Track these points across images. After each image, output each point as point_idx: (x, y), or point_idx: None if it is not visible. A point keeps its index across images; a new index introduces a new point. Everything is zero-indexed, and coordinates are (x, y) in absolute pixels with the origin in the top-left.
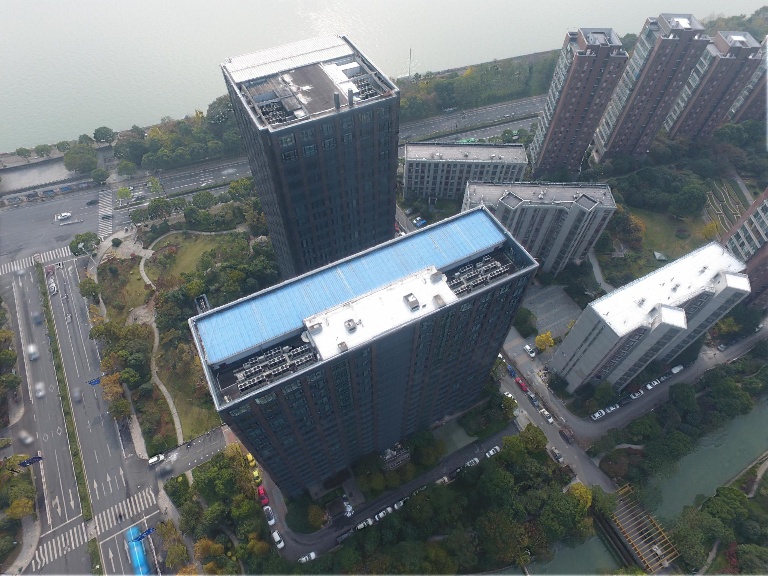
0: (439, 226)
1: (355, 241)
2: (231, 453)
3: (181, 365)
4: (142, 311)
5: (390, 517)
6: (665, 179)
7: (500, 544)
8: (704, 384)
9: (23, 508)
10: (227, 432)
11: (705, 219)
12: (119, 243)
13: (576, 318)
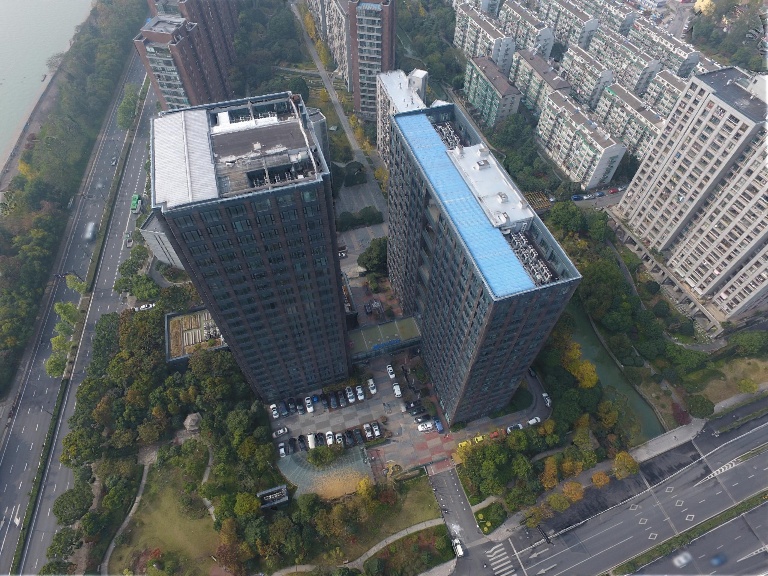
0: None
1: None
2: None
3: (364, 508)
4: None
5: None
6: None
7: None
8: None
9: None
10: (435, 470)
11: None
12: None
13: (373, 188)
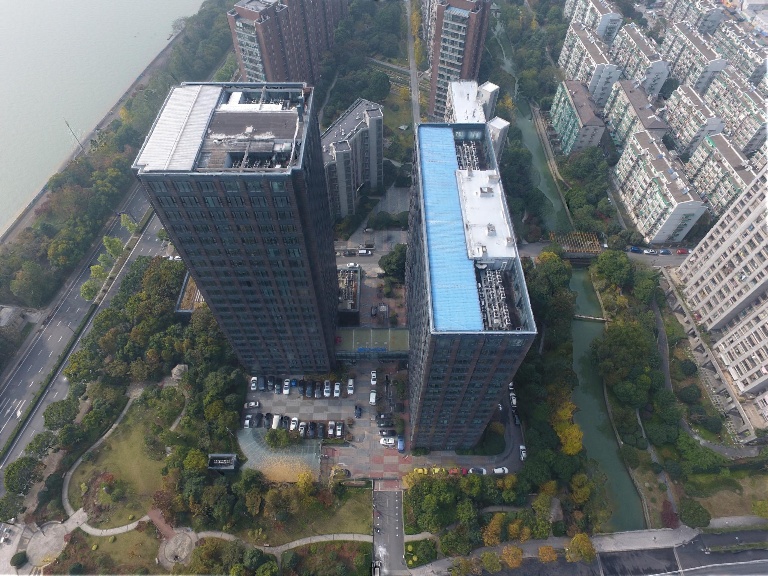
0: (420, 152)
1: (327, 246)
2: (418, 478)
3: (295, 501)
4: (169, 546)
5: (524, 370)
6: (351, 84)
7: (570, 308)
8: (504, 164)
9: None
10: (382, 487)
11: (391, 92)
12: (24, 556)
13: None
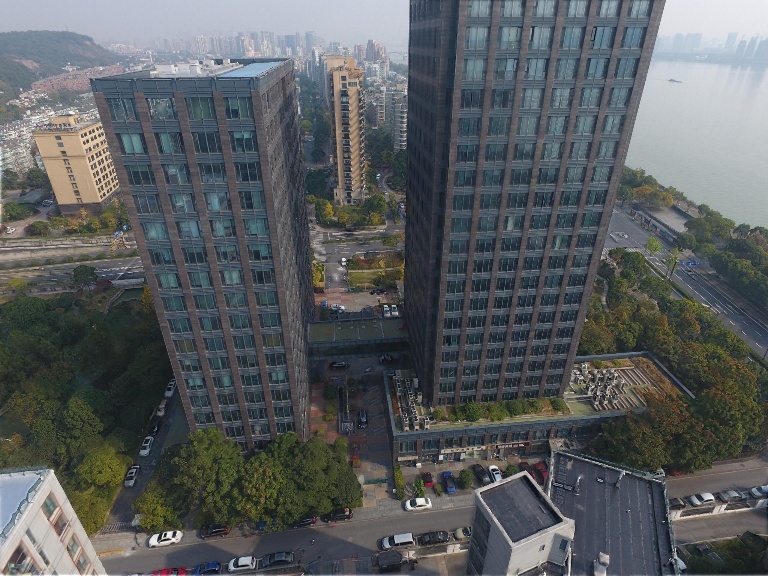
0: None
1: None
2: None
3: None
4: None
5: None
6: None
7: None
8: None
9: (342, 216)
10: (342, 290)
11: None
12: None
13: None
